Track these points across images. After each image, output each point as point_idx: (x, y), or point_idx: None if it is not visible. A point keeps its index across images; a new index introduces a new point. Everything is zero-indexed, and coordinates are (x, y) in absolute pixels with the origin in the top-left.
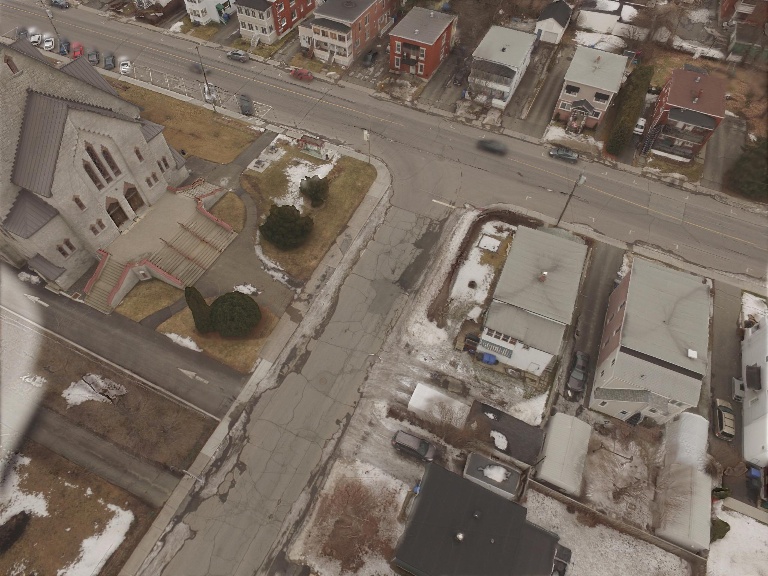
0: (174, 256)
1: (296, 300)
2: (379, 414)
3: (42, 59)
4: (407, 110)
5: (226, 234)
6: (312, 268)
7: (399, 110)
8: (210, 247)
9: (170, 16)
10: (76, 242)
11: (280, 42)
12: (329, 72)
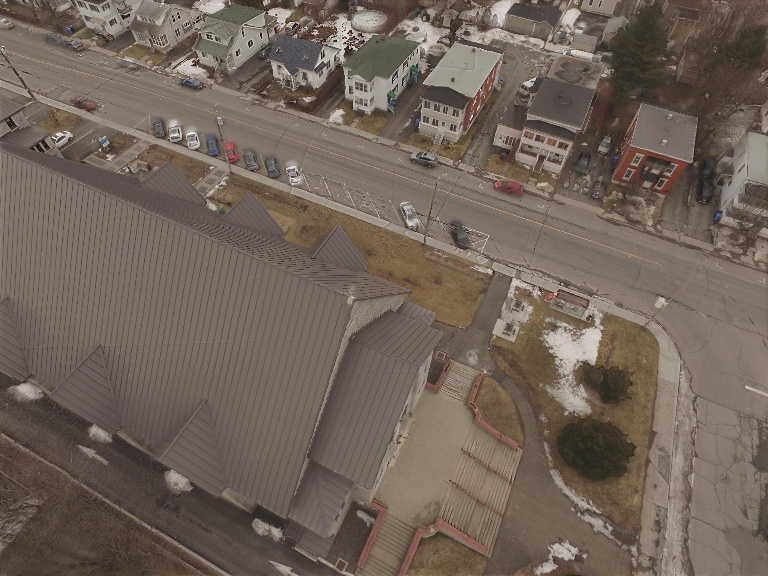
0: (464, 501)
1: (637, 569)
2: None
3: (265, 216)
4: (654, 240)
5: (511, 453)
6: (637, 509)
7: (644, 240)
8: (499, 478)
9: (324, 101)
10: (348, 496)
11: (466, 139)
12: (539, 183)
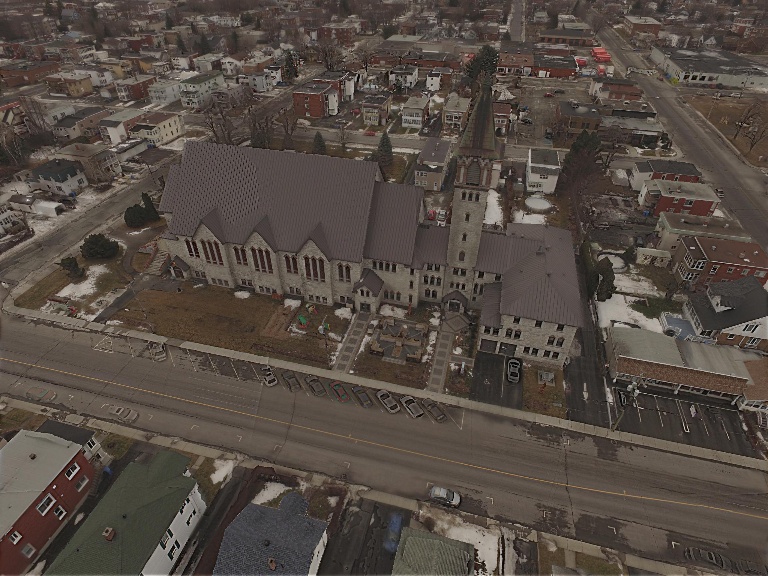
0: None
1: None
2: (80, 208)
3: None
4: None
5: None
6: None
7: None
8: None
9: None
10: None
11: None
12: None
